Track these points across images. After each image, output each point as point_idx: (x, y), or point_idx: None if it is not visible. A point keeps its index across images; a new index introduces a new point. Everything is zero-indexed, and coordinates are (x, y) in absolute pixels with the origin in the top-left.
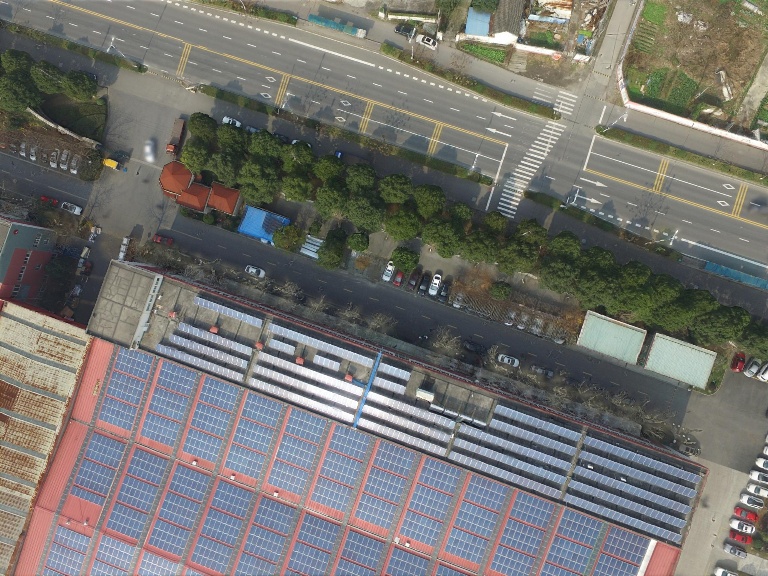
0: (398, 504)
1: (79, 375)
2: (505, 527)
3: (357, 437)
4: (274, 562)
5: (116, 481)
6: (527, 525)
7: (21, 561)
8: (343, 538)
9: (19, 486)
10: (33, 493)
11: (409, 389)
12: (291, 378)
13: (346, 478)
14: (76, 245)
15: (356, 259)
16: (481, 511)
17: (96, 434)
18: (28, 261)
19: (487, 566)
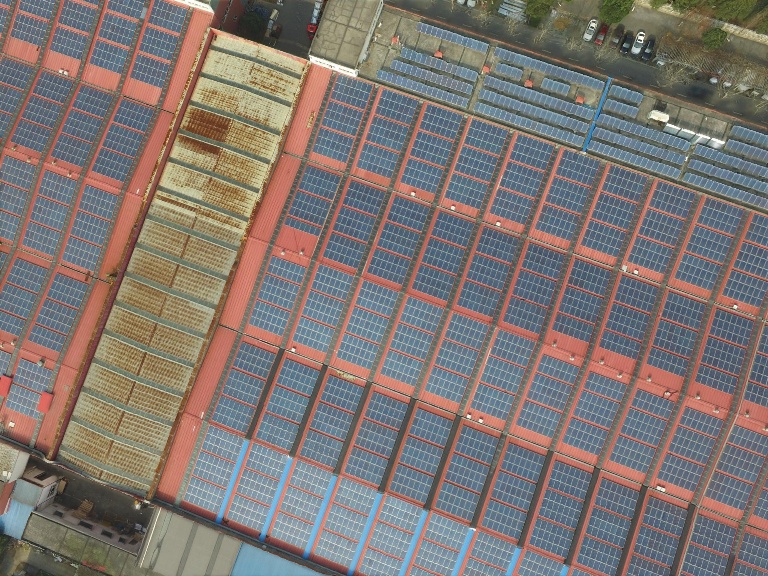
0: (627, 230)
1: (296, 103)
2: (739, 251)
3: (586, 162)
4: (498, 289)
5: (331, 212)
6: (763, 248)
7: (231, 295)
8: (568, 266)
9: (230, 219)
10: (247, 223)
11: (640, 114)
12: (519, 102)
13: (573, 205)
14: (265, 7)
15: (555, 20)
16: (714, 235)
17: (309, 167)
18: (231, 4)
19: (718, 293)
